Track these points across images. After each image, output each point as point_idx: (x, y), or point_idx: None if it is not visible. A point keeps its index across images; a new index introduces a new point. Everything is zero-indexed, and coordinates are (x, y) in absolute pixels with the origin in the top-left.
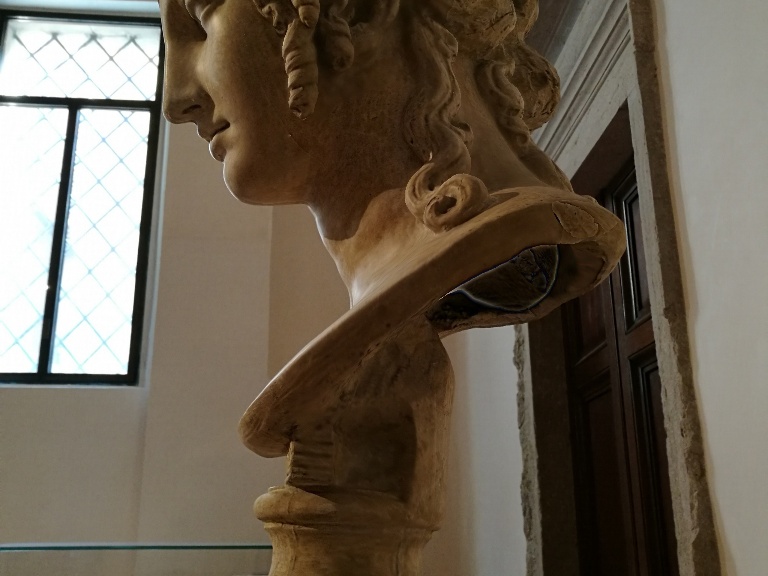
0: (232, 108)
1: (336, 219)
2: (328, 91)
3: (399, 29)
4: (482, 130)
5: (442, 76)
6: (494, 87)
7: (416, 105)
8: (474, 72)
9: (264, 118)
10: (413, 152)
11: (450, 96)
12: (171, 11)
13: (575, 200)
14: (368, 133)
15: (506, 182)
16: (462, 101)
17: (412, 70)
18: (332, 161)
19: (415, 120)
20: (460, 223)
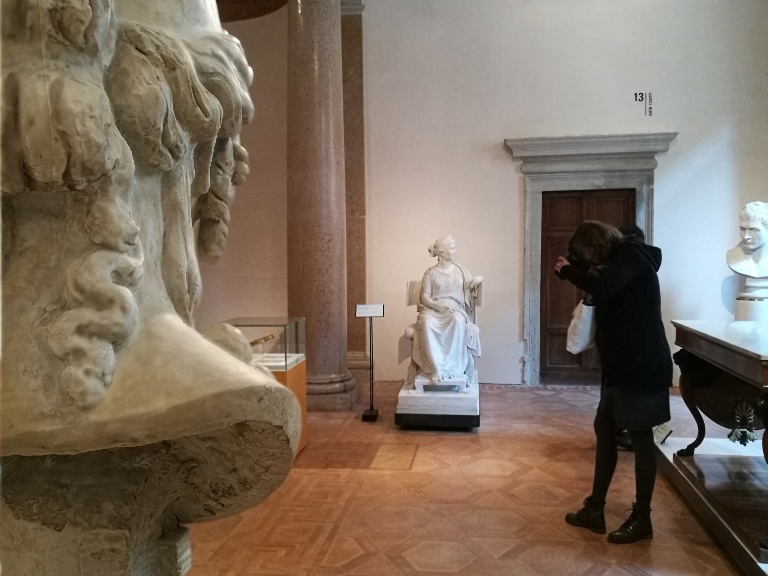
0: None
1: None
2: None
3: None
4: None
5: None
6: None
7: None
8: None
9: None
10: None
11: None
12: None
13: None
14: None
15: None
16: None
17: None
18: None
19: None
20: None
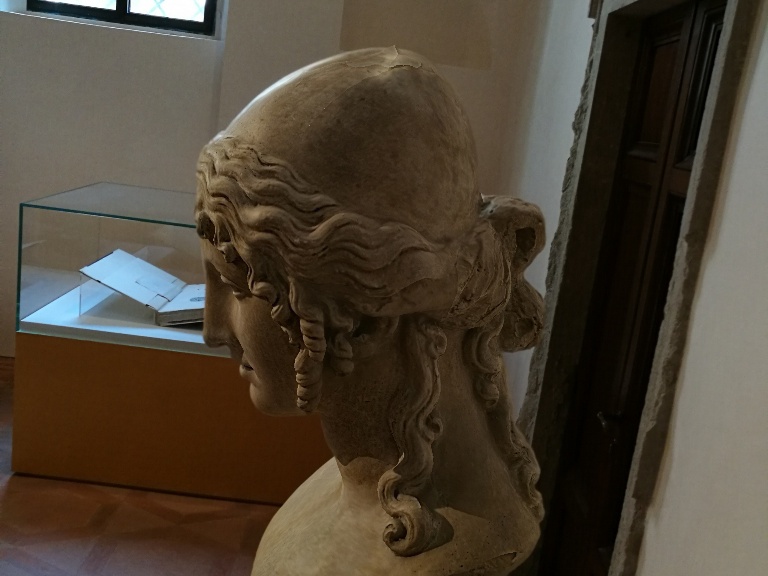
0: (256, 370)
1: (333, 447)
2: (332, 379)
3: (398, 328)
4: (454, 412)
5: (425, 383)
6: (476, 361)
7: (399, 409)
8: (463, 340)
9: (280, 388)
10: (393, 437)
11: (429, 398)
12: (210, 265)
13: (510, 495)
14: (361, 411)
15: (456, 490)
16: (443, 383)
17: (404, 363)
18: (332, 415)
19: (396, 424)
20: (405, 556)
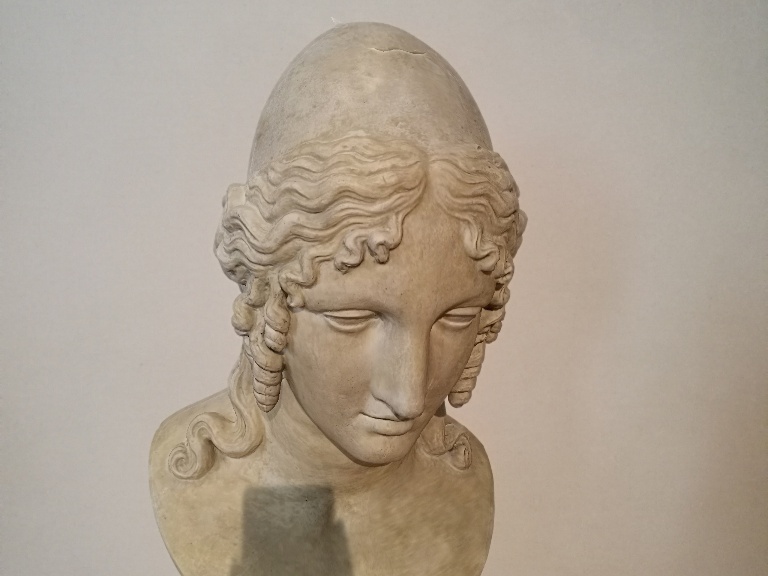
0: None
1: None
2: None
3: None
4: None
5: None
6: None
7: None
8: None
9: None
10: None
11: None
12: None
13: None
14: None
15: None
16: None
17: None
18: None
19: None
20: (471, 463)
